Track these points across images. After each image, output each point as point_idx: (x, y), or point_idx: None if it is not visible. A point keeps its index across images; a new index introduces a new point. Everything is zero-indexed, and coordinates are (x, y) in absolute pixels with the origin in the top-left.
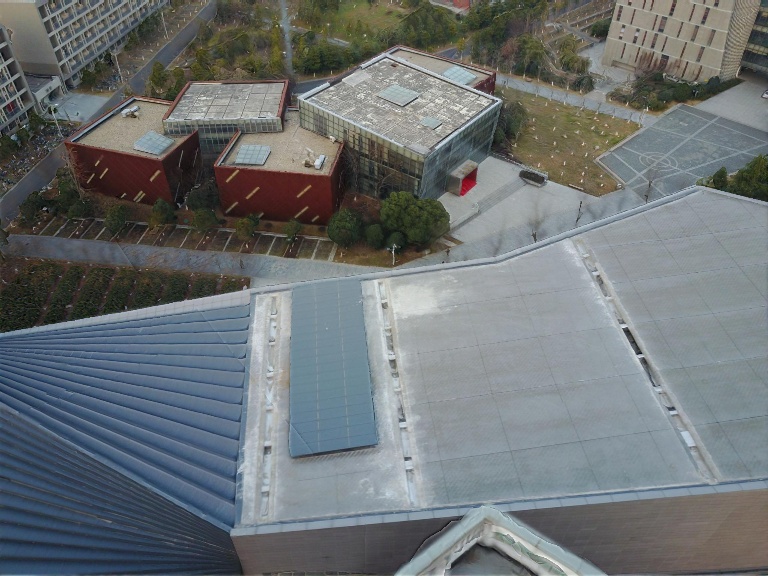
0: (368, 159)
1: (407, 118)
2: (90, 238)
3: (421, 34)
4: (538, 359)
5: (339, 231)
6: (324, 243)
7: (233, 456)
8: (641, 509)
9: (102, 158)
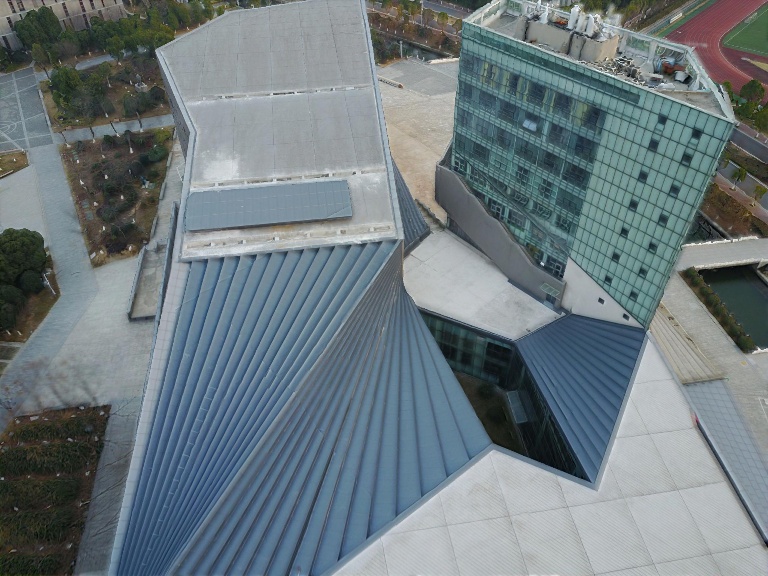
0: None
1: None
2: None
3: None
4: (291, 124)
5: (4, 310)
6: None
7: (347, 248)
8: None
9: None
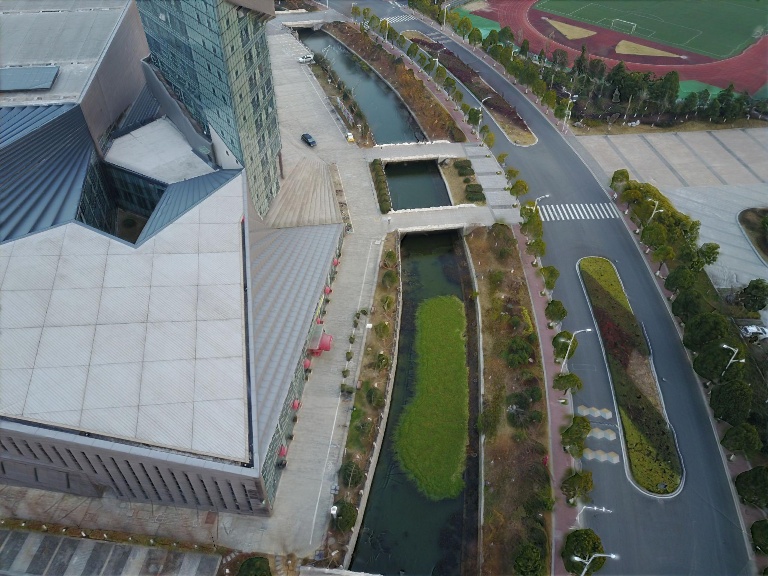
0: None
1: None
2: None
3: None
4: (43, 31)
5: None
6: None
7: None
8: (125, 27)
9: None
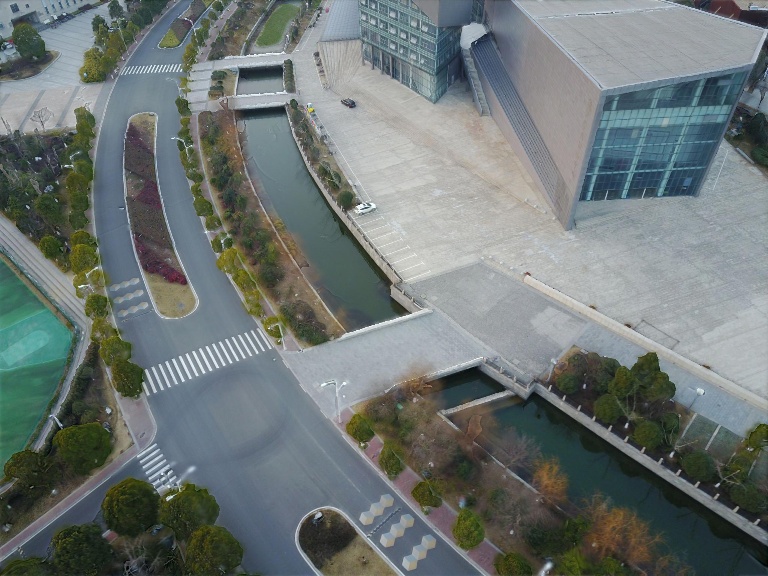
0: None
1: None
2: None
3: None
4: (583, 1)
5: None
6: None
7: None
8: None
9: None
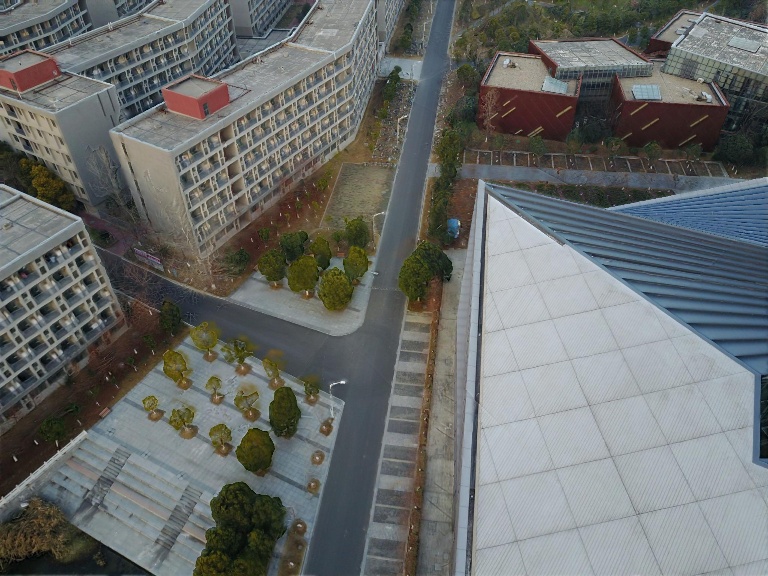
0: (737, 96)
1: (766, 61)
2: (510, 165)
3: (670, 4)
4: None
5: (745, 150)
6: (711, 165)
7: None
8: None
9: (515, 98)
